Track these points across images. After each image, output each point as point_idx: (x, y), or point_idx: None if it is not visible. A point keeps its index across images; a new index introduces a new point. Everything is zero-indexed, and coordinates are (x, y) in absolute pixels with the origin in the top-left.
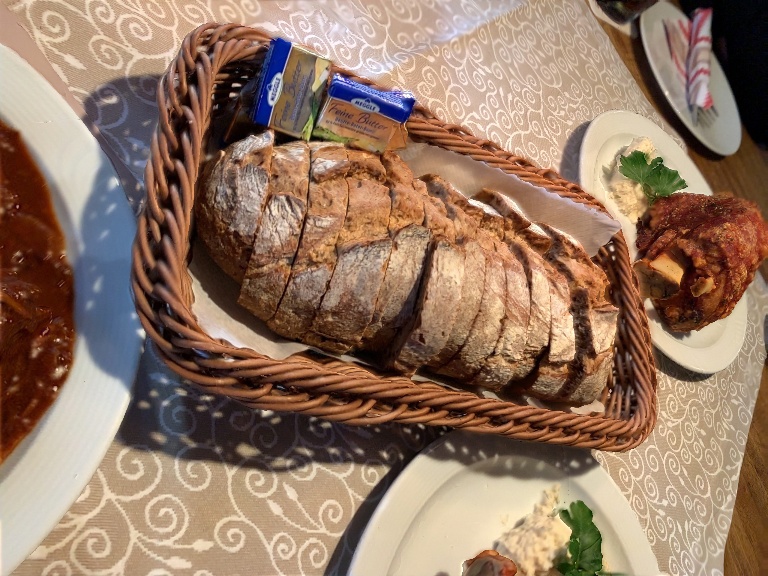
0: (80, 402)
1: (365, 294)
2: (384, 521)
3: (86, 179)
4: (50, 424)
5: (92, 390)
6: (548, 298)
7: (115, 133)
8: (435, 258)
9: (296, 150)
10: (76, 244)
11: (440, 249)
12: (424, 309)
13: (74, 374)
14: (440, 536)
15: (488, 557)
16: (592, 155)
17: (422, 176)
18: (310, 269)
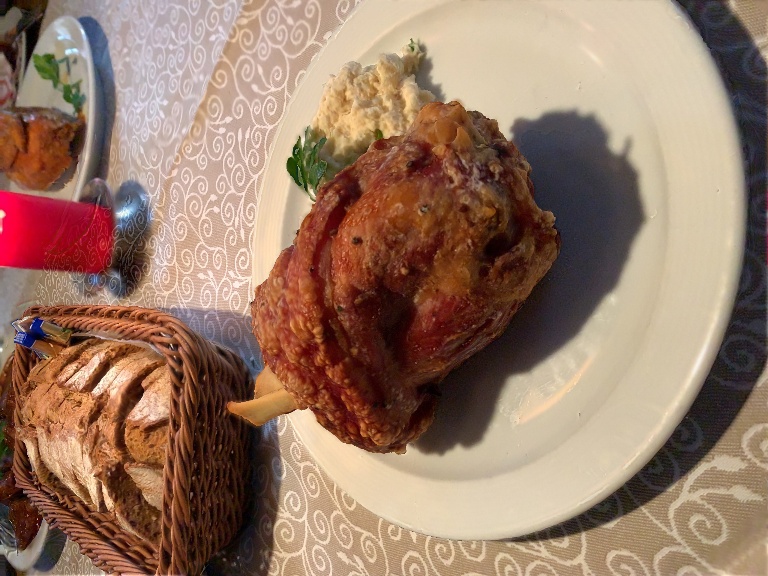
0: None
1: None
2: None
3: None
4: None
5: None
6: (81, 459)
7: None
8: None
9: None
10: None
11: None
12: None
13: None
14: None
15: None
16: (284, 171)
17: None
18: None
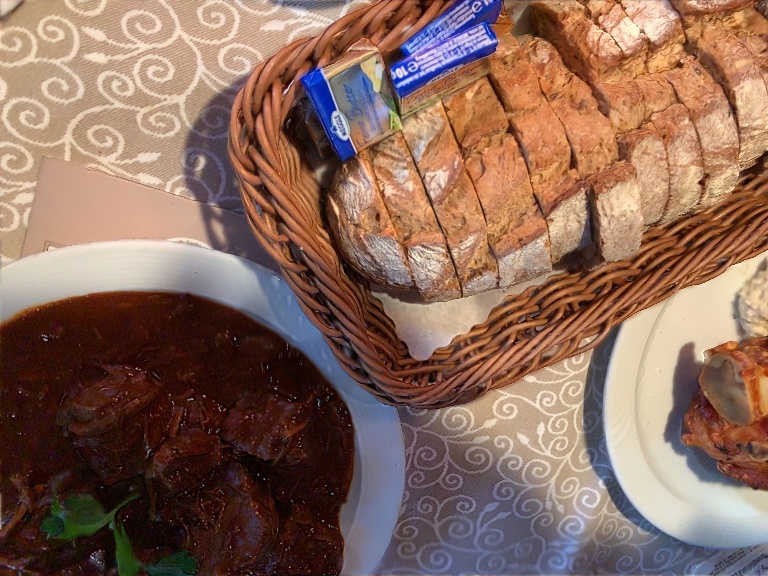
0: (369, 427)
1: (537, 265)
2: (621, 360)
3: (256, 292)
4: (362, 445)
5: (371, 417)
6: (765, 101)
7: (229, 193)
8: (599, 207)
9: (400, 172)
10: (289, 336)
11: (602, 197)
12: (603, 251)
13: (353, 413)
14: (678, 322)
15: (726, 355)
16: None
17: (546, 8)
18: (476, 278)
